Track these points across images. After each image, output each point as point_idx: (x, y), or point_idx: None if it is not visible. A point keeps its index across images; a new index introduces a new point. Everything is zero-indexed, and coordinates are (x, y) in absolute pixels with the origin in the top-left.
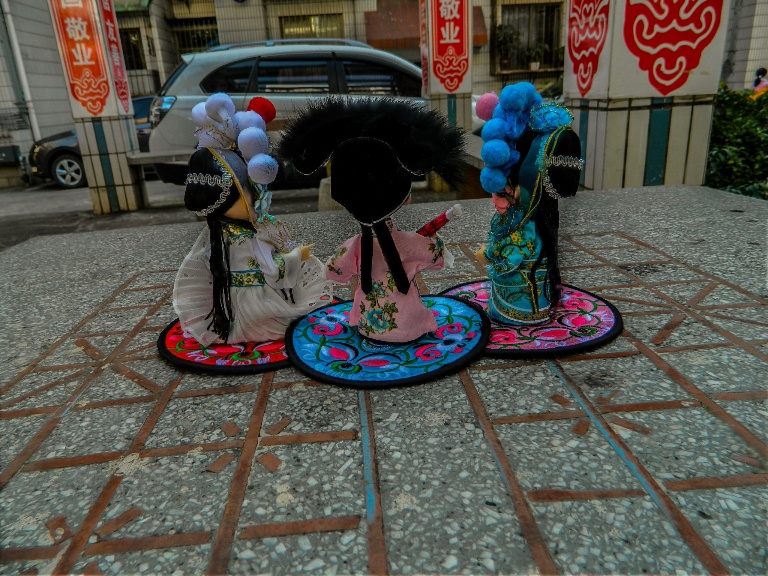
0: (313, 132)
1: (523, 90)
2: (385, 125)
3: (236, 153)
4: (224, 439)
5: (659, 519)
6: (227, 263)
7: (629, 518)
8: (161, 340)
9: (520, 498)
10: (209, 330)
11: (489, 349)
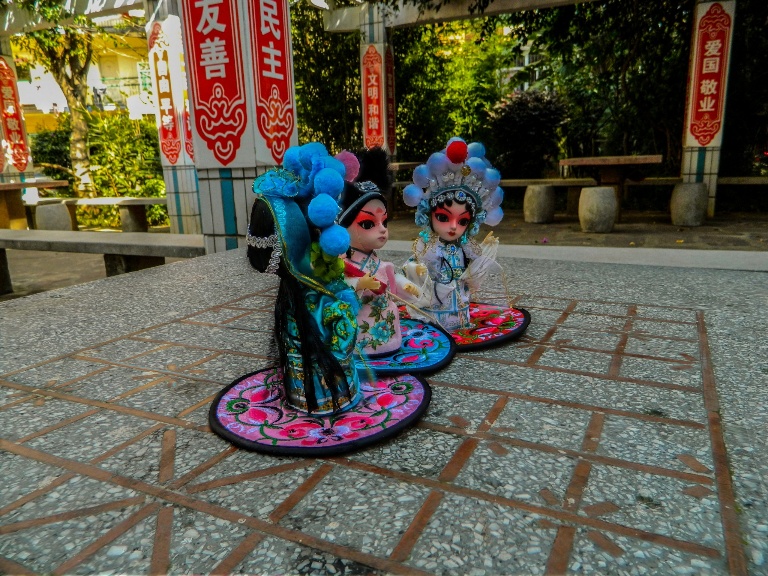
0: None
1: (287, 153)
2: None
3: None
4: None
5: None
6: None
7: None
8: None
9: None
10: None
11: None
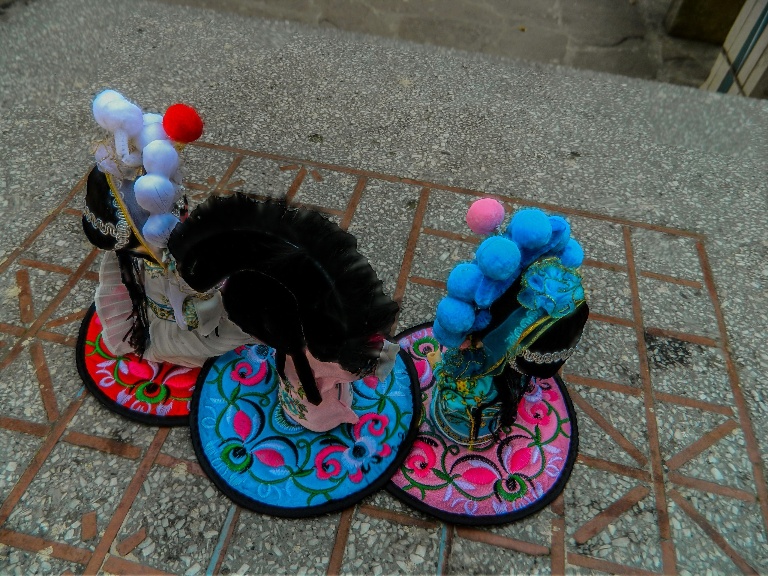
0: (209, 240)
1: (515, 259)
2: (298, 270)
3: None
4: (76, 543)
5: None
6: (142, 287)
7: None
8: (85, 323)
9: None
10: (125, 341)
11: (392, 485)
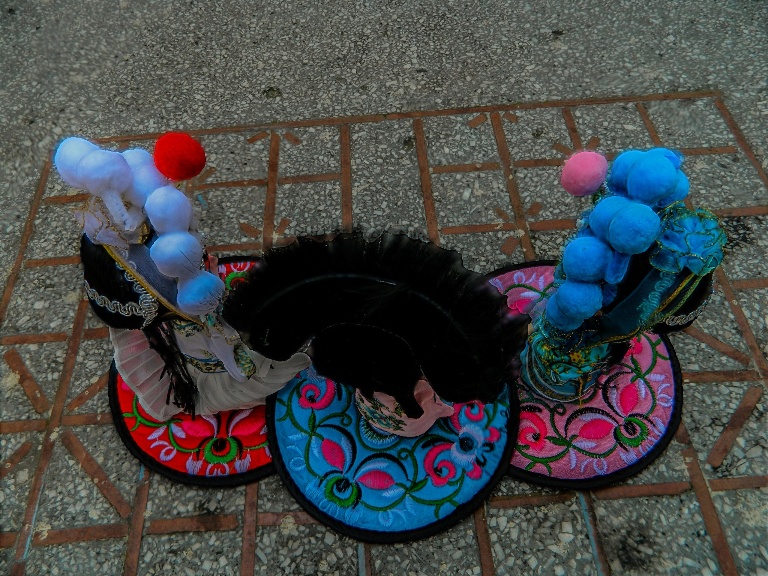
0: (278, 302)
1: (657, 227)
2: (402, 310)
3: None
4: None
5: None
6: (175, 346)
7: None
8: (112, 394)
9: None
10: (169, 404)
11: (513, 469)
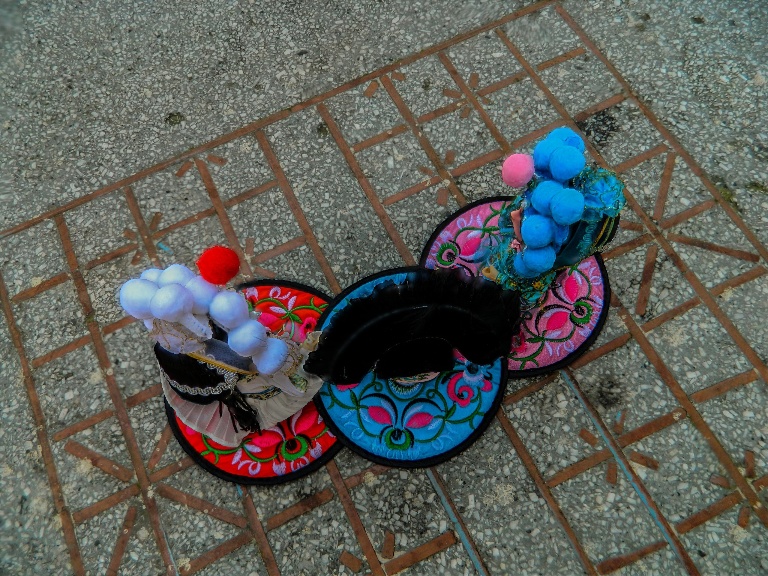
0: (348, 348)
1: (584, 203)
2: (437, 321)
3: (222, 341)
4: None
5: (678, 567)
6: (236, 391)
7: (661, 572)
8: (183, 443)
9: (594, 575)
10: (238, 432)
11: (512, 373)
